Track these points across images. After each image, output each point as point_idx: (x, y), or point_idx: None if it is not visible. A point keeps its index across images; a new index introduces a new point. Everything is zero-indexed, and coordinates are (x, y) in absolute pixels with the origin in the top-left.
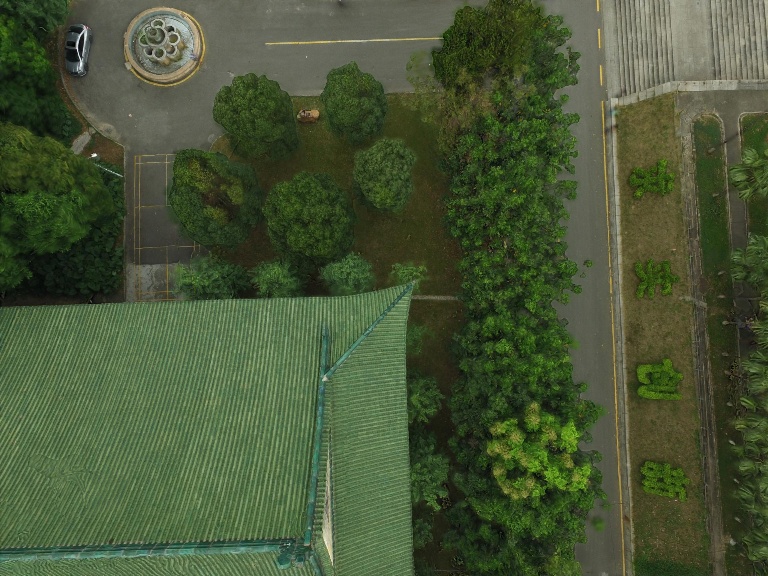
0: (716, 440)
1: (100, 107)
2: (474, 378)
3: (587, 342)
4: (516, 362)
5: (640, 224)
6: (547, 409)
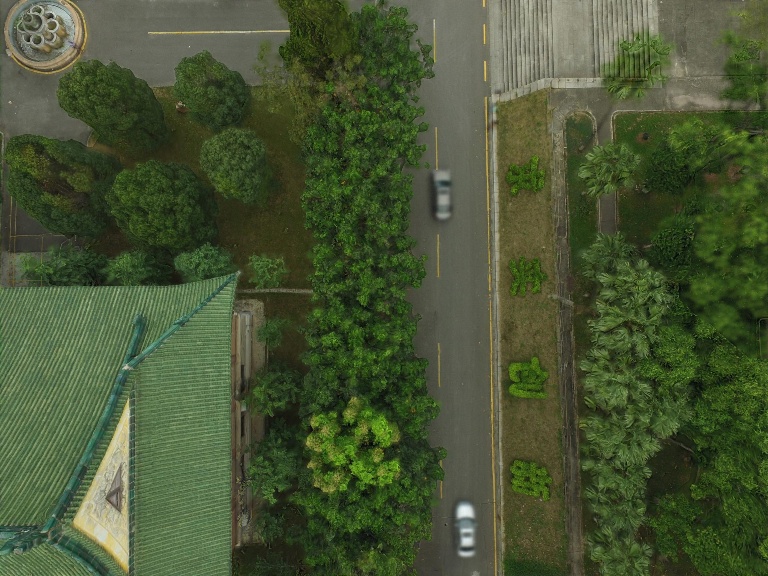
0: (578, 440)
1: None
2: (310, 371)
3: (464, 339)
4: (339, 355)
5: (516, 221)
6: (382, 404)
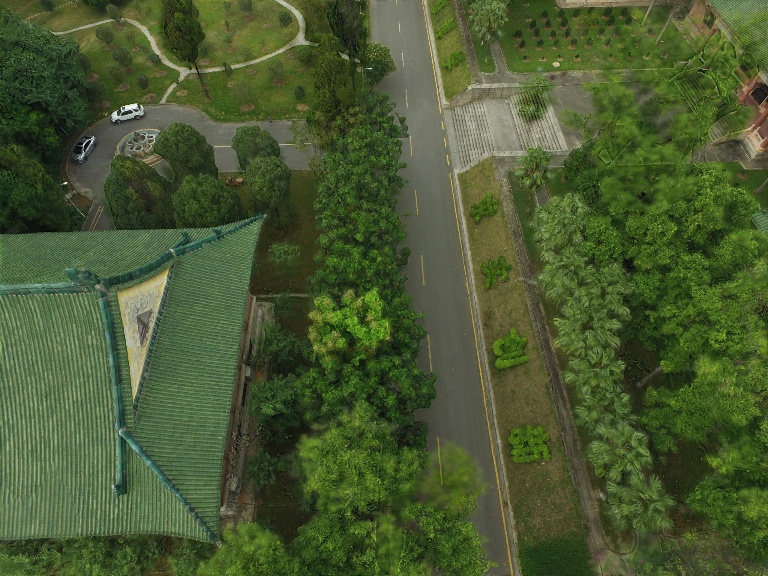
0: (566, 392)
1: (86, 180)
2: (314, 296)
3: (451, 332)
4: (339, 264)
5: (482, 239)
6: None
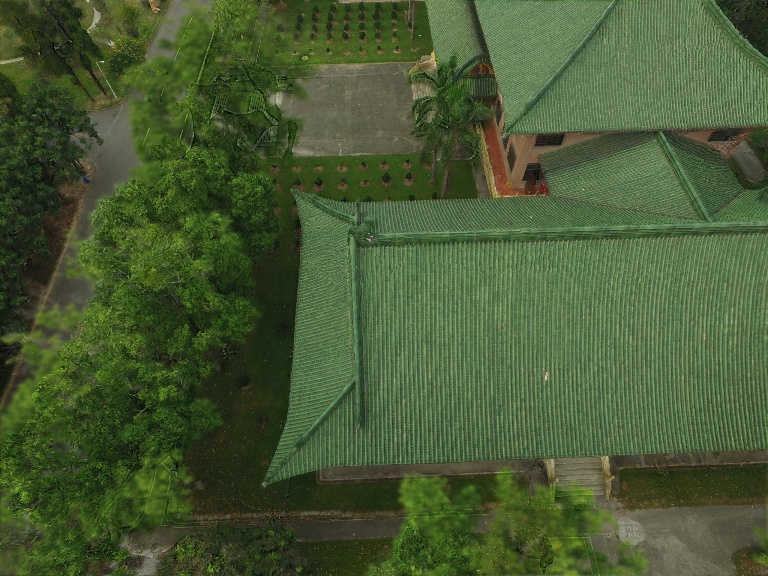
0: None
1: None
2: None
3: None
4: None
5: None
6: None
